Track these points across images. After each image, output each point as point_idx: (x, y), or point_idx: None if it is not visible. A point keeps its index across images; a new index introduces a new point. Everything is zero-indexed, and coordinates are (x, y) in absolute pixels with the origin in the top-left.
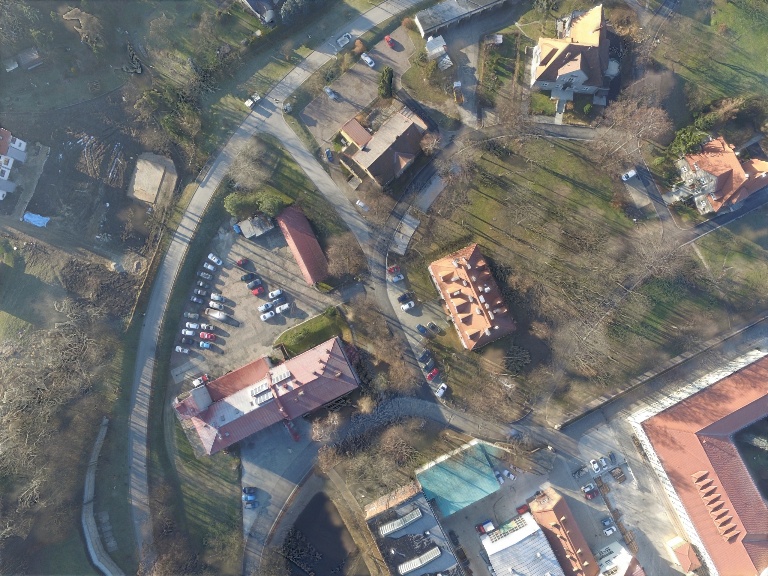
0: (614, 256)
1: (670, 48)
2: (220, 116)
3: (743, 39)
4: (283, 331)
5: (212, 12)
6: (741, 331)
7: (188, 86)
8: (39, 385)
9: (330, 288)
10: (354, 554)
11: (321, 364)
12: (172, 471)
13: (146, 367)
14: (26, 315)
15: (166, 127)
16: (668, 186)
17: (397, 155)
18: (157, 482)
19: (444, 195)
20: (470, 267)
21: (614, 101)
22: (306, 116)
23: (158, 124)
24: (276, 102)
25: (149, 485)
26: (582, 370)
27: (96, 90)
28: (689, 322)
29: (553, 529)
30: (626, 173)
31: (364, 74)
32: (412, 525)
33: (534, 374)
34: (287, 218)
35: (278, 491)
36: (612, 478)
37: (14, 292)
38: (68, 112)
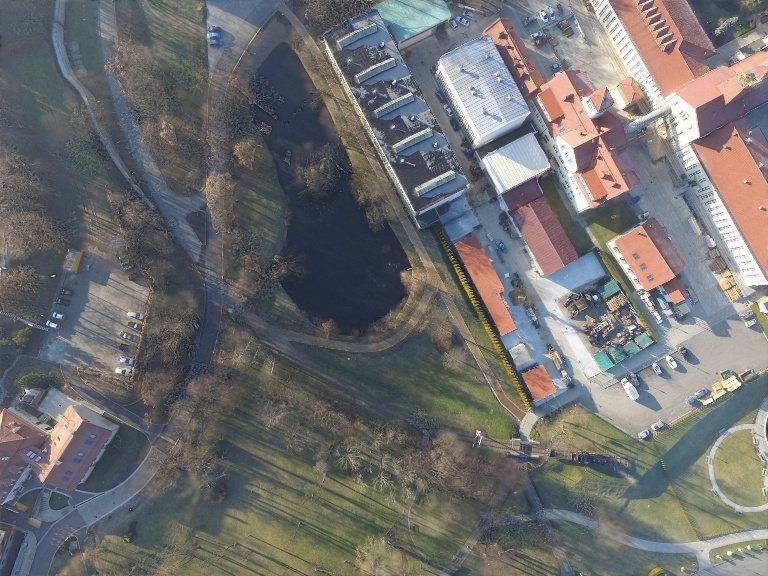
0: None
1: None
2: None
3: None
4: None
5: None
6: None
7: None
8: None
9: None
10: (315, 95)
11: None
12: (140, 12)
13: None
14: None
15: None
16: None
17: None
18: (125, 17)
19: None
20: None
21: None
22: None
23: None
24: None
25: (117, 19)
26: None
27: None
28: None
29: (501, 42)
30: None
31: None
32: (367, 38)
33: None
34: None
35: (242, 34)
36: (560, 32)
37: None
38: None
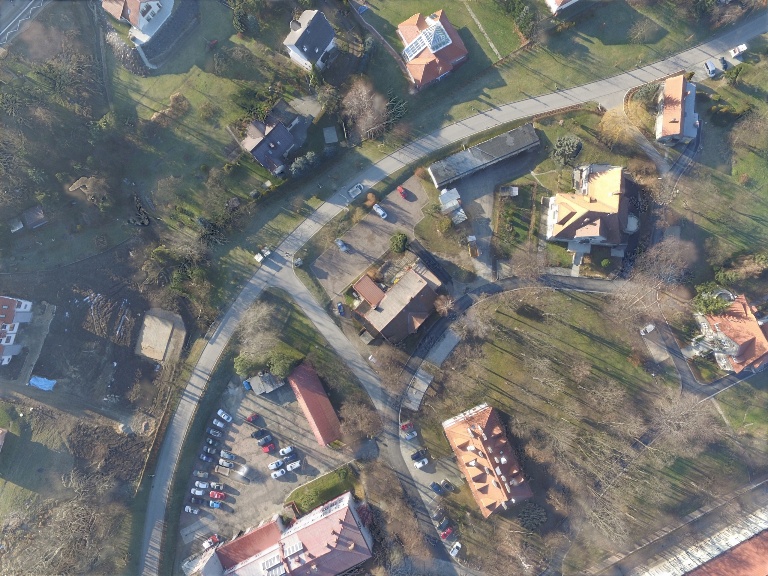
0: (632, 411)
1: (690, 198)
2: (229, 270)
3: (765, 189)
4: (294, 488)
5: (221, 162)
6: (761, 484)
7: (196, 240)
8: (47, 571)
9: (342, 444)
10: None
11: (334, 535)
12: None
13: (155, 530)
14: (33, 485)
15: (174, 283)
16: (687, 340)
17: (411, 316)
18: None
19: (458, 349)
20: (486, 438)
21: (632, 253)
22: (317, 268)
23: (166, 277)
24: (286, 255)
25: None
26: (599, 527)
27: (103, 246)
28: (708, 479)
29: None
30: (645, 328)
31: (376, 225)
32: None
33: (550, 537)
34: (298, 378)
35: None
36: None
37: (21, 462)
38: (74, 269)
